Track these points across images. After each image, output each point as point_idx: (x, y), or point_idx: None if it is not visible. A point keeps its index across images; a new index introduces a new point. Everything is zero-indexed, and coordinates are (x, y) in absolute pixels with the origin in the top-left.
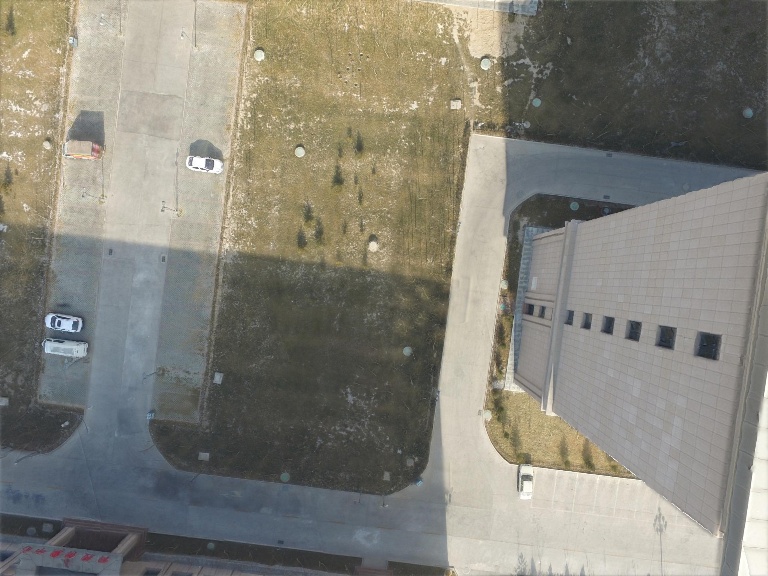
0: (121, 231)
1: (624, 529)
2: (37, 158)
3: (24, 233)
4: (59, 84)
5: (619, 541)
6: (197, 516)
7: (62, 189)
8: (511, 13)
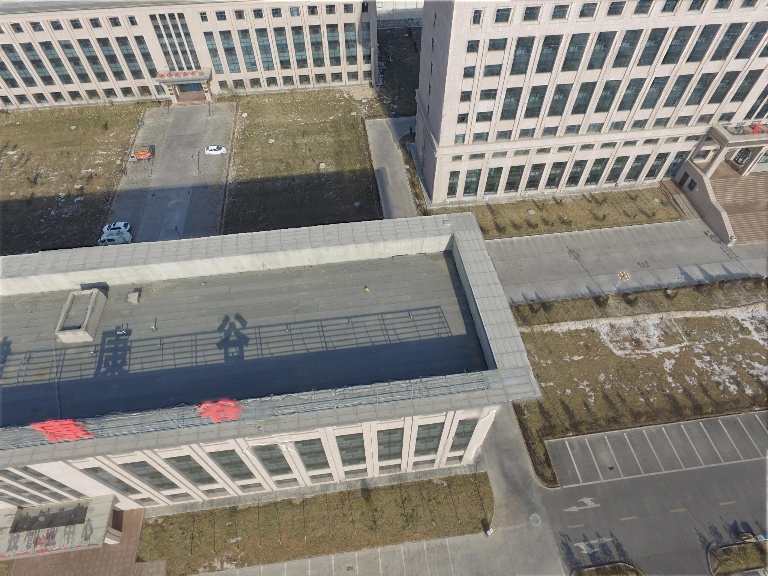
0: (161, 186)
1: (550, 263)
2: (111, 168)
3: (95, 198)
4: (130, 141)
5: (551, 271)
6: None
7: (125, 176)
8: None
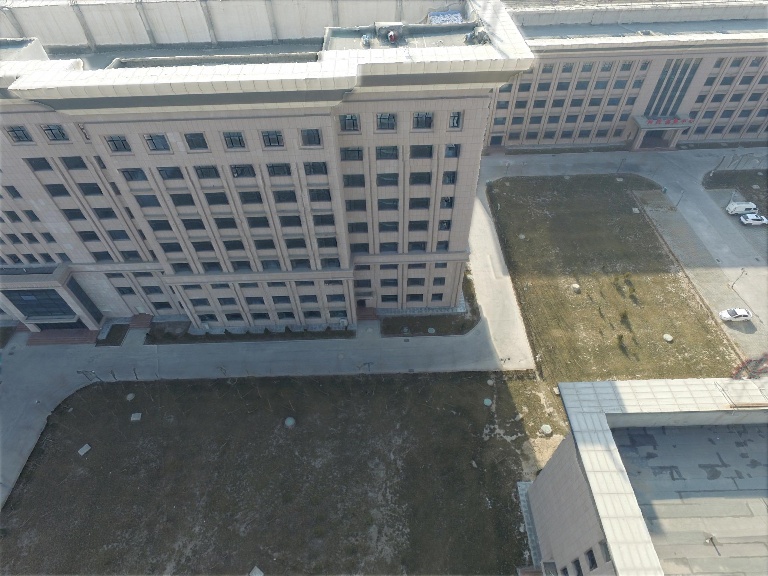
0: (761, 272)
1: None
2: None
3: None
4: None
5: None
6: (606, 159)
7: None
8: None
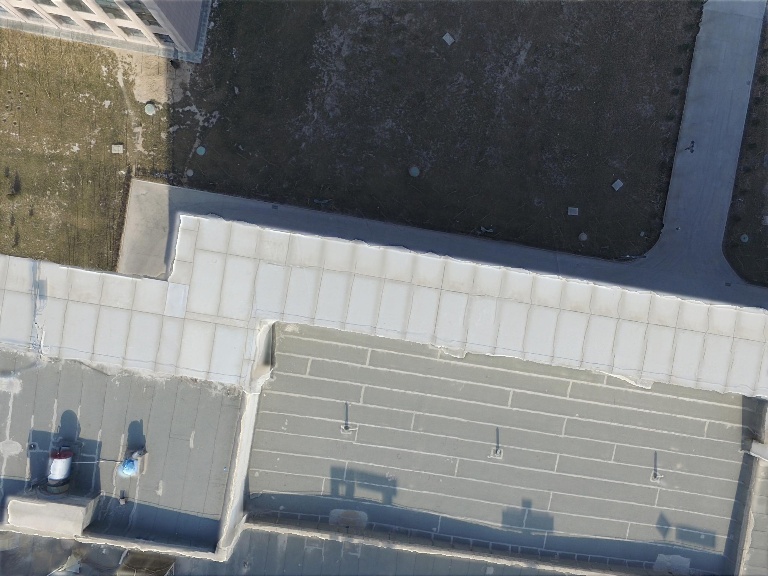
0: None
1: None
2: None
3: None
4: None
5: None
6: None
7: None
8: (176, 59)
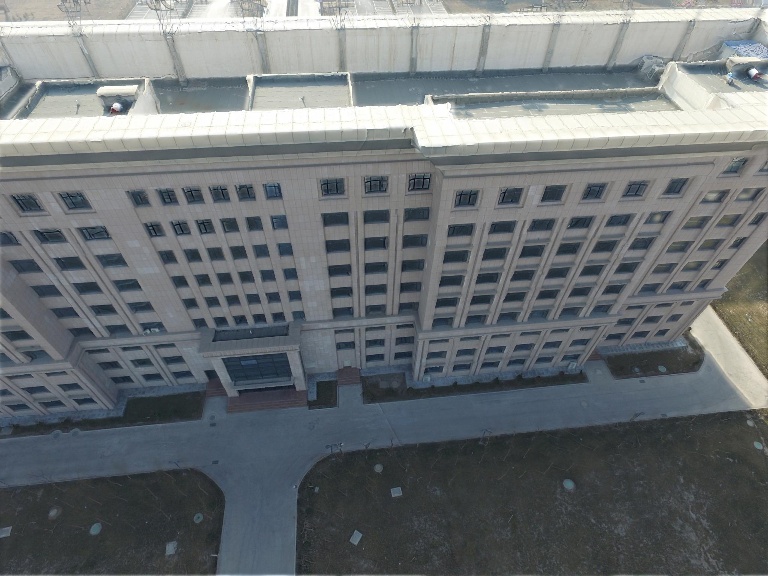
0: None
1: None
2: None
3: None
4: None
5: None
6: None
7: None
8: None
